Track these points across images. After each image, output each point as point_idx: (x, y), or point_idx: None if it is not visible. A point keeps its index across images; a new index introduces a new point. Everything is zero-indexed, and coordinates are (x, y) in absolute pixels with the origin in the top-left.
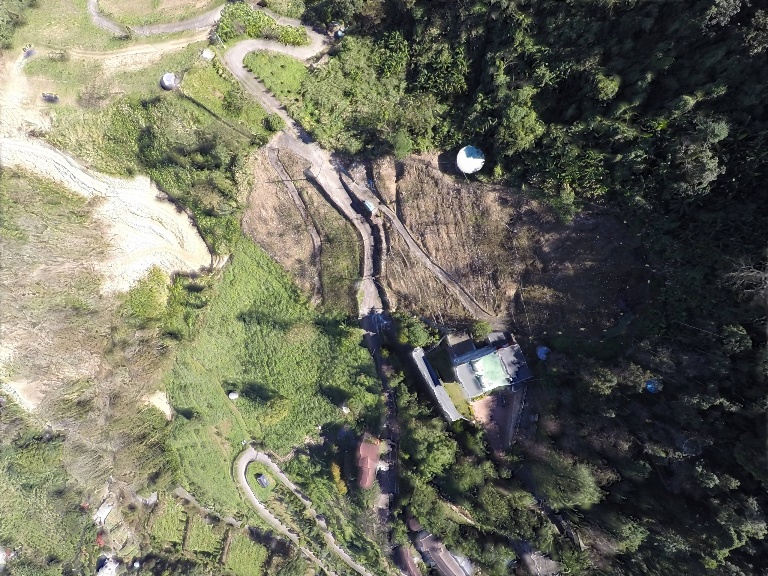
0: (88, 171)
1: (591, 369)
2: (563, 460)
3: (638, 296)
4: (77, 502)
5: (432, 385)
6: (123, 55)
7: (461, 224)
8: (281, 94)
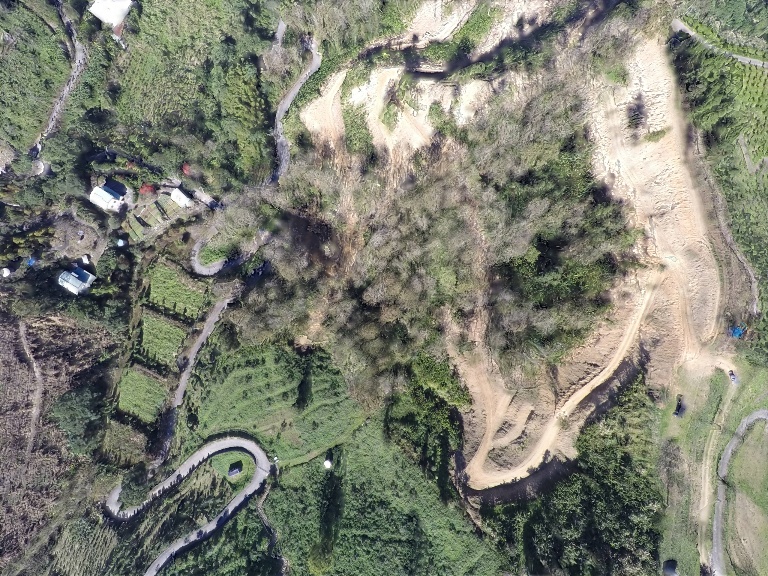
0: (588, 409)
1: None
2: None
3: None
4: (187, 156)
5: None
6: None
7: None
8: None
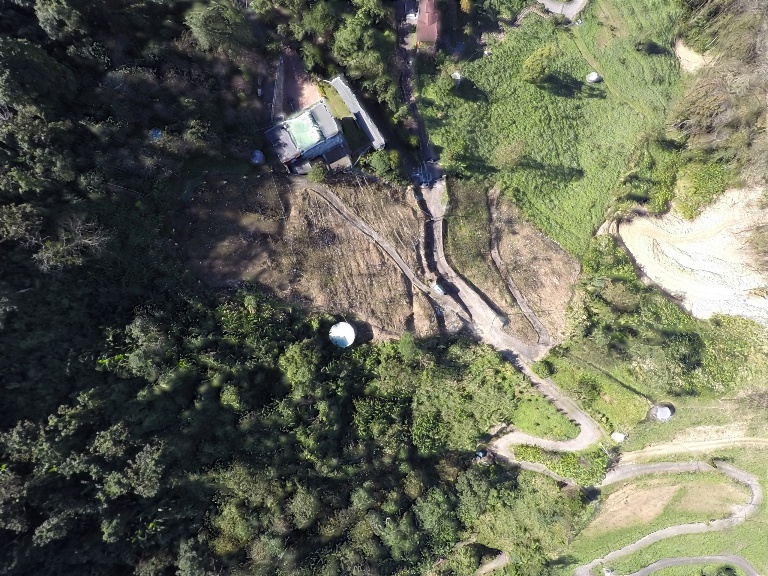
0: None
1: (212, 144)
2: (228, 51)
3: (181, 217)
4: None
5: (363, 112)
6: (722, 440)
7: (346, 275)
8: (538, 398)
